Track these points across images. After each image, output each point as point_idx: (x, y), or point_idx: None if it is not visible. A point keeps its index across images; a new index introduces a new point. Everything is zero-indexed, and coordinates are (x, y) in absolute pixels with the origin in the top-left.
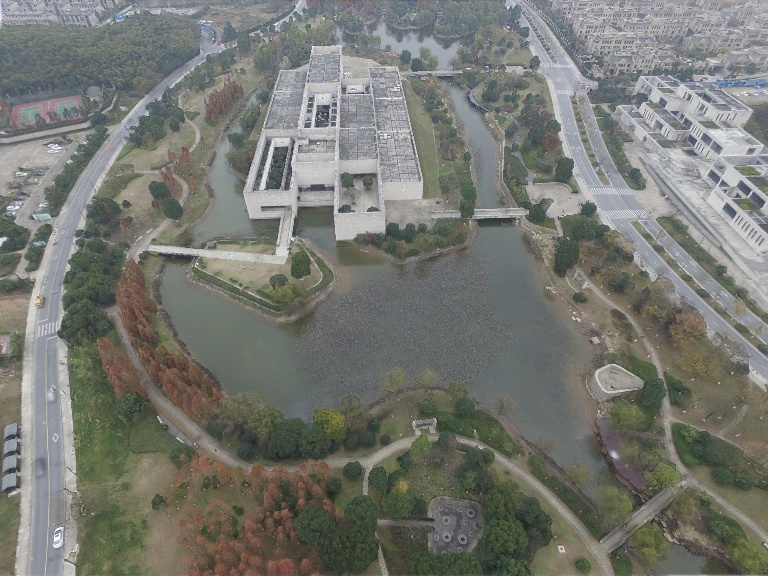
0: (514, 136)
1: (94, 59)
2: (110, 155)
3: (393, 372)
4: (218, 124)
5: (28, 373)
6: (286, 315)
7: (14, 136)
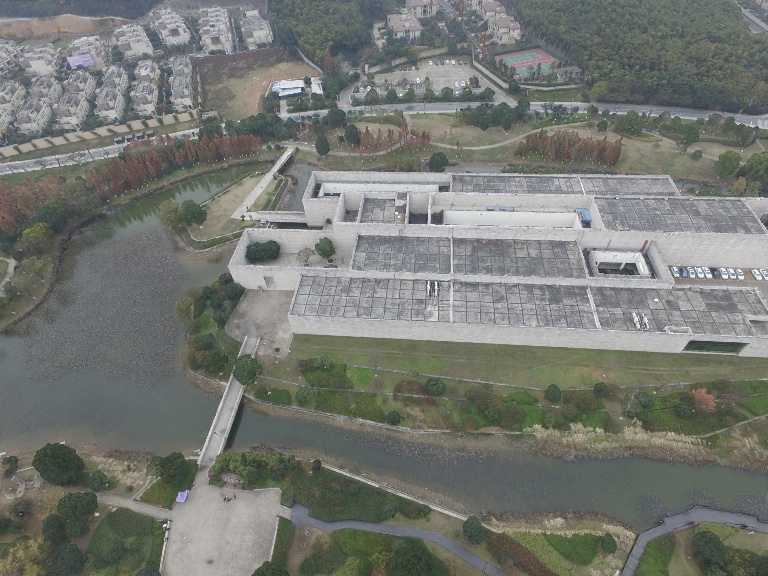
0: (476, 547)
1: (623, 47)
2: (450, 109)
3: (37, 260)
4: (522, 157)
5: (193, 130)
6: (174, 224)
7: (477, 62)
